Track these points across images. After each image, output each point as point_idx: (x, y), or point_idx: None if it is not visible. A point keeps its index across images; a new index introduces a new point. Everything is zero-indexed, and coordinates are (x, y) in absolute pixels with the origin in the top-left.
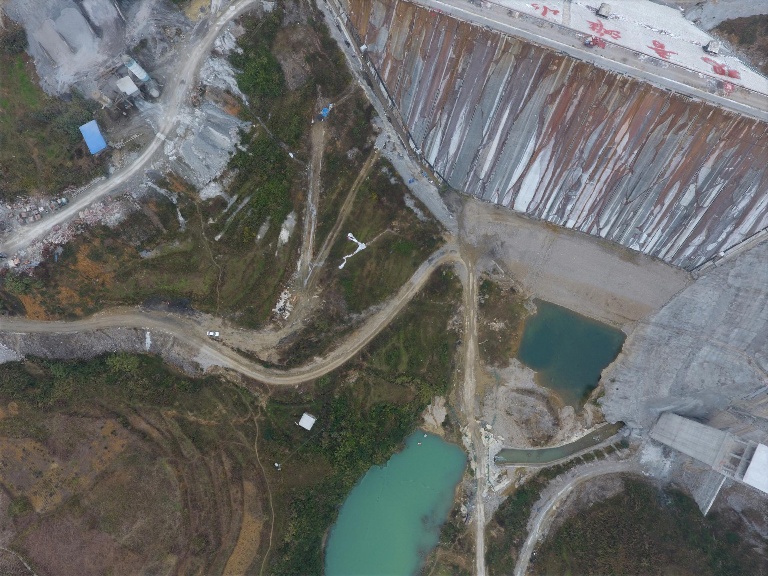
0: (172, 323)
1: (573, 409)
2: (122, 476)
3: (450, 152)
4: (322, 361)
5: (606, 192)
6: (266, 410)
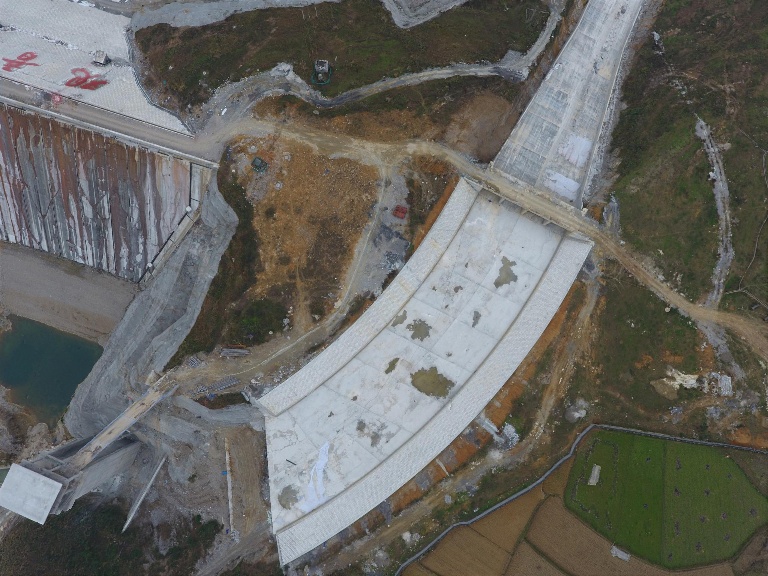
0: None
1: (46, 426)
2: None
3: None
4: None
5: (19, 206)
6: None
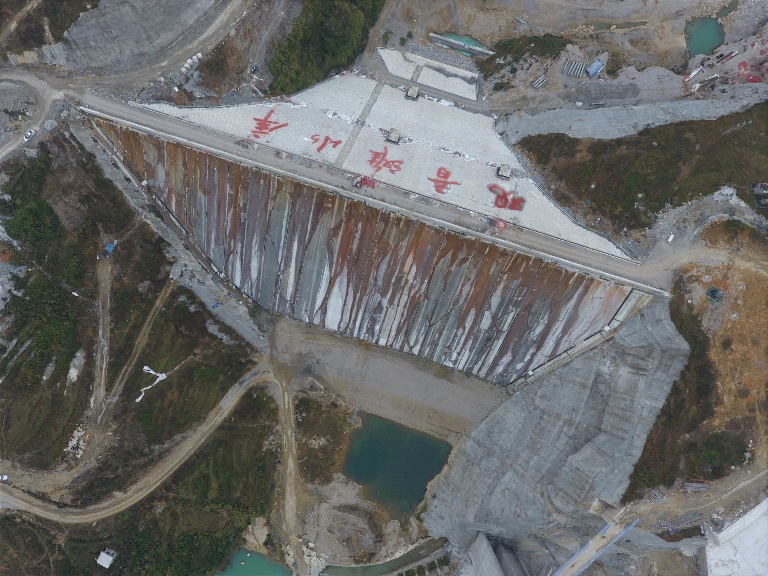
0: None
1: (399, 523)
2: None
3: (252, 276)
4: (122, 495)
5: (408, 315)
6: (64, 548)
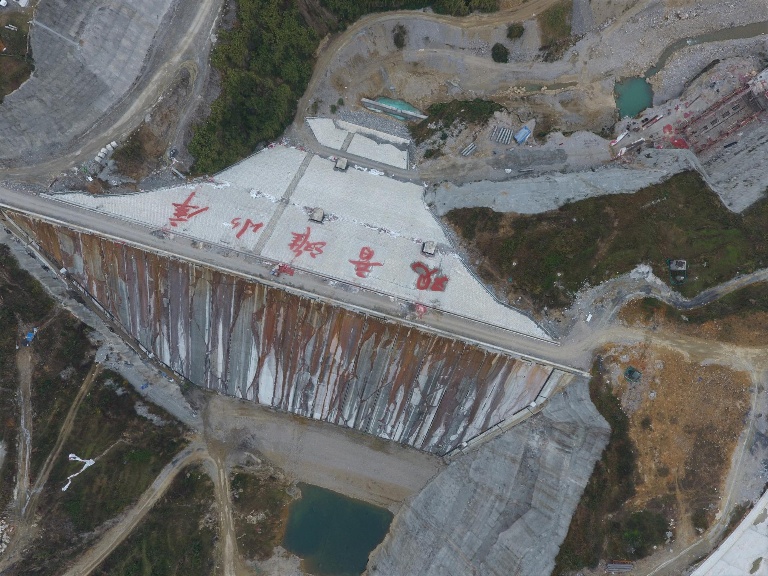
0: None
1: None
2: None
3: (181, 356)
4: None
5: (339, 392)
6: None
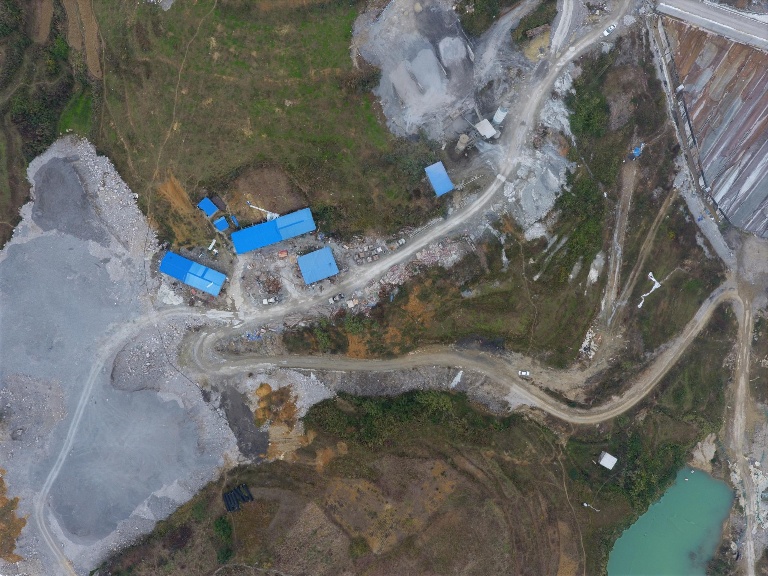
0: (484, 362)
1: None
2: (453, 517)
3: (741, 190)
4: (619, 400)
5: None
6: (566, 449)
